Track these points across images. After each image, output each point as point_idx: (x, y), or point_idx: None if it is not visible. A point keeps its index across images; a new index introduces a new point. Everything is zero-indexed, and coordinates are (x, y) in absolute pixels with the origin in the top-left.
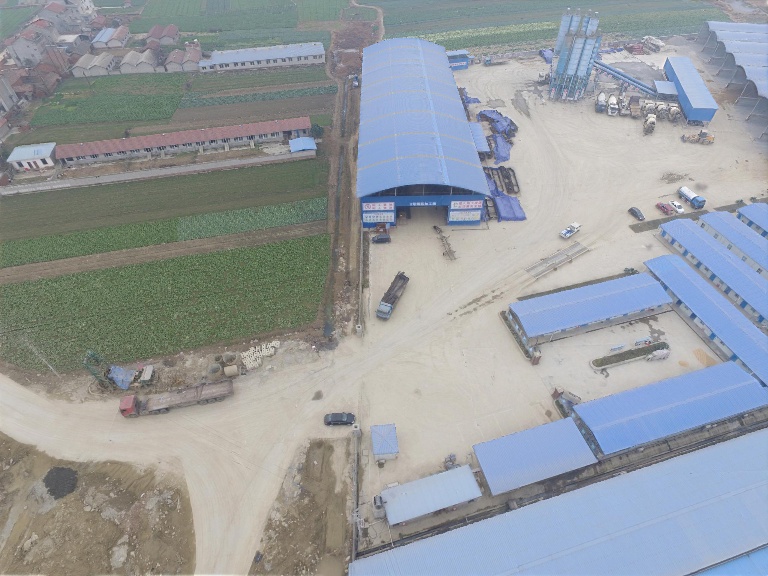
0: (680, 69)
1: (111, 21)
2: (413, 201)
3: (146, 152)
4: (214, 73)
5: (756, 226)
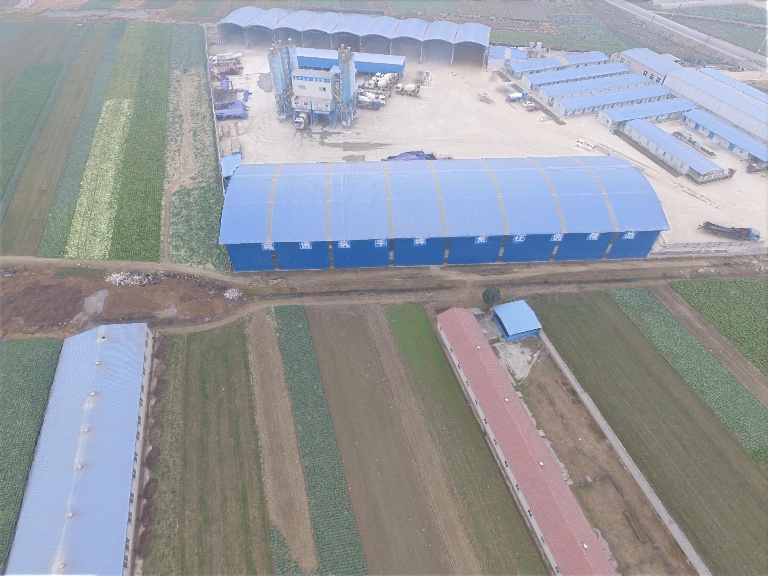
0: (322, 55)
1: None
2: None
3: None
4: None
5: None
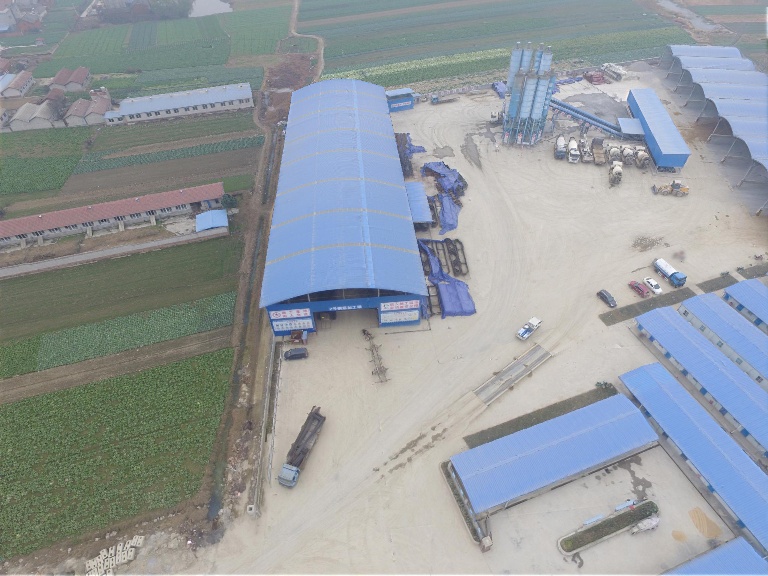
0: (645, 104)
1: (15, 64)
2: (332, 305)
3: (19, 239)
4: (123, 125)
5: (748, 311)
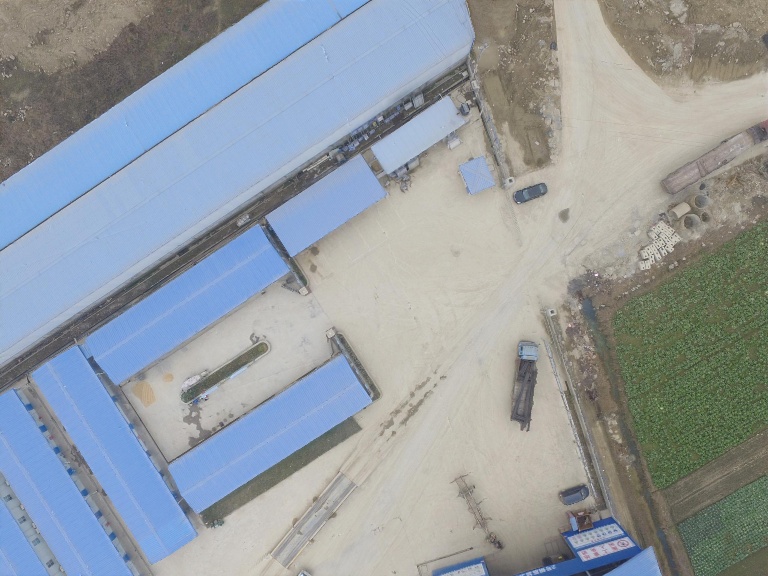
0: None
1: None
2: (553, 572)
3: None
4: None
5: None
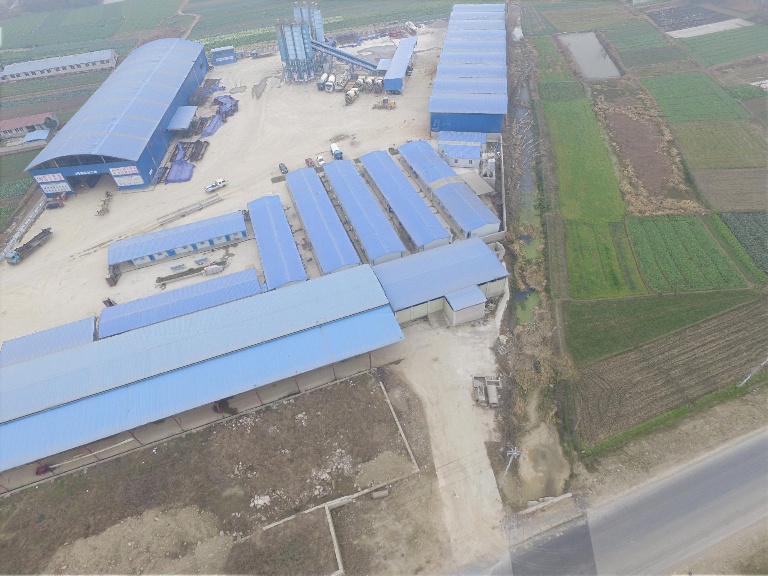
0: (402, 48)
1: None
2: (76, 171)
3: None
4: (6, 83)
5: None
